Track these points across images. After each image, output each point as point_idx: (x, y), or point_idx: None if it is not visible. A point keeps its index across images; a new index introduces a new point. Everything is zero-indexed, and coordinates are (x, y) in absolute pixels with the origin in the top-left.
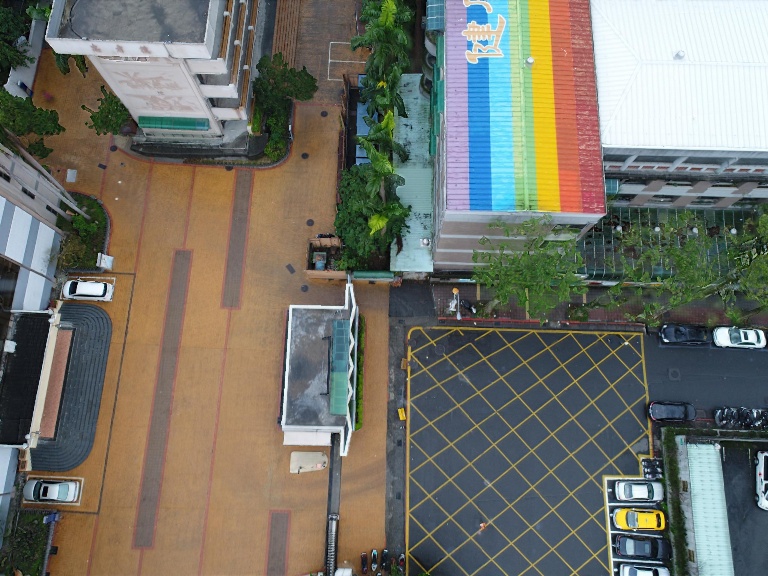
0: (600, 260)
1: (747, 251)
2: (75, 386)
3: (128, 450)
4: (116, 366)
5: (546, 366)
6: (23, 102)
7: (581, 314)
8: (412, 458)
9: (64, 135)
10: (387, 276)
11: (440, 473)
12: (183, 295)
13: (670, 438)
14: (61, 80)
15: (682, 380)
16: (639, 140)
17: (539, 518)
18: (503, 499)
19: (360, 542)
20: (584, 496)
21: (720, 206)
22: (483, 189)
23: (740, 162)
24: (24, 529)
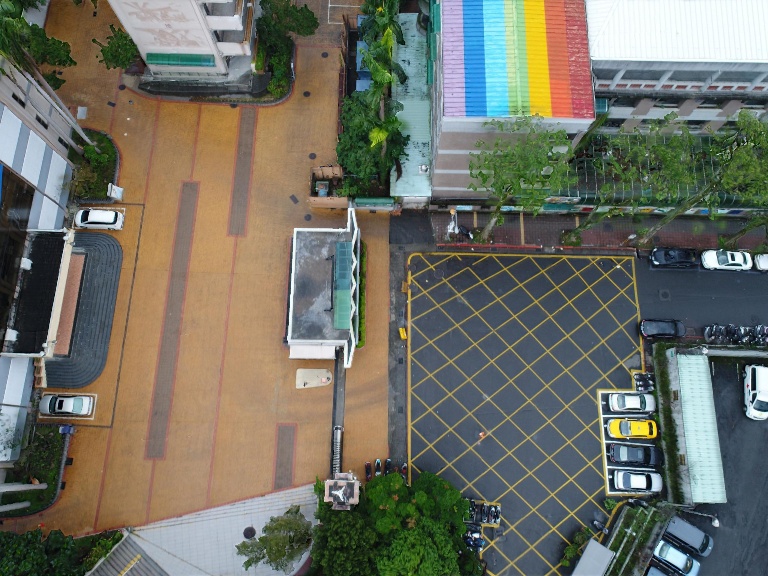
0: (592, 184)
1: (728, 146)
2: (88, 307)
3: (139, 368)
4: (127, 290)
5: (541, 288)
6: (38, 28)
7: (574, 239)
8: (413, 375)
9: (74, 75)
10: (387, 202)
11: (440, 388)
12: (191, 224)
13: (661, 352)
14: (71, 24)
15: (672, 300)
16: (626, 53)
17: (536, 429)
18: (501, 412)
19: (364, 453)
20: (579, 408)
21: (706, 132)
22: (478, 97)
23: (723, 77)
24: (41, 440)
